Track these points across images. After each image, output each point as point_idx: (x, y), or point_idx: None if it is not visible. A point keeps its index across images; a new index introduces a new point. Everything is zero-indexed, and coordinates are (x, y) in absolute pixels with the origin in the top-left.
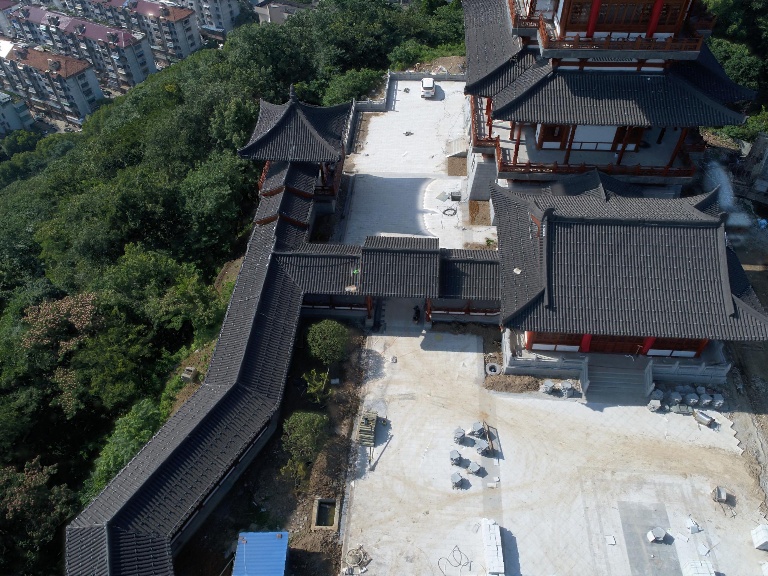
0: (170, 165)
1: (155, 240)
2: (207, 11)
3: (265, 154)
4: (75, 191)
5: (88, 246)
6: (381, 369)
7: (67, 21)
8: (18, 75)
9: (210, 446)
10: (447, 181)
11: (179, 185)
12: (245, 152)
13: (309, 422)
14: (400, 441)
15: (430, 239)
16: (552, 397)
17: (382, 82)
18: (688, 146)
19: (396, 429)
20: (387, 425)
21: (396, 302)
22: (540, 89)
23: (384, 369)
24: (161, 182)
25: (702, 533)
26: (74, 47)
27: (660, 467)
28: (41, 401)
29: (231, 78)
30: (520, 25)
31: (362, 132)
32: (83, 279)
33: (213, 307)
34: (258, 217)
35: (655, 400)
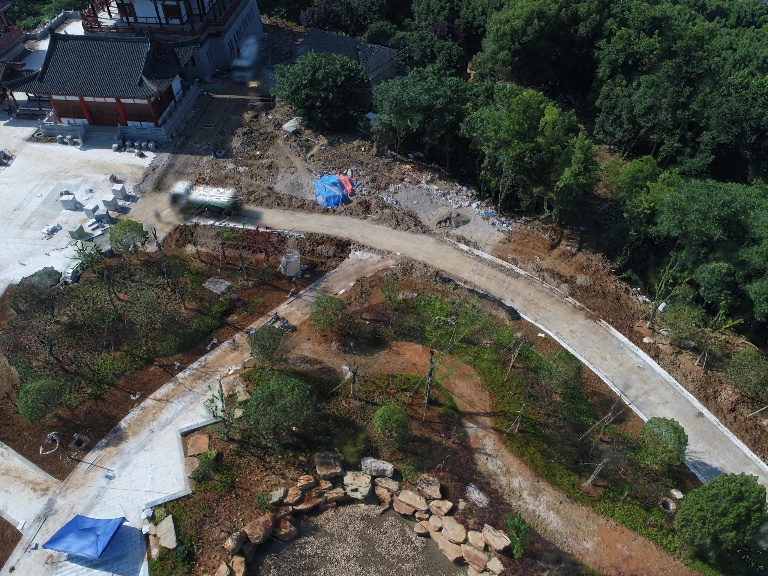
0: None
1: None
2: None
3: None
4: None
5: None
6: None
7: None
8: None
9: None
10: None
11: None
12: None
13: None
14: None
15: None
16: (61, 145)
17: None
18: (212, 21)
19: None
20: None
21: (6, 106)
22: None
23: None
24: None
25: (92, 193)
26: None
27: (95, 171)
28: None
29: None
30: None
31: (59, 29)
32: None
33: None
34: None
35: (115, 144)
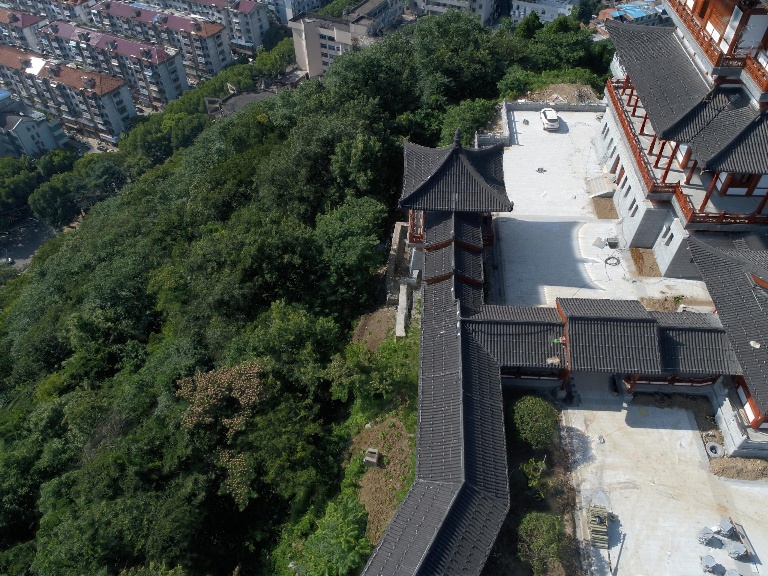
0: (288, 206)
1: (287, 292)
2: (237, 25)
3: (426, 203)
4: (187, 235)
5: (221, 301)
6: (589, 451)
7: (98, 37)
8: (50, 92)
9: (450, 562)
10: (599, 225)
11: (315, 233)
12: (405, 202)
13: (550, 527)
14: (636, 541)
15: (630, 301)
16: None
17: (496, 112)
18: None
19: (627, 526)
20: (615, 521)
21: None
22: (748, 135)
23: (593, 451)
24: (296, 230)
25: None
26: (105, 63)
27: None
28: (207, 488)
29: (341, 110)
30: (722, 64)
31: None
32: (217, 338)
33: (389, 378)
34: (427, 275)
35: None
